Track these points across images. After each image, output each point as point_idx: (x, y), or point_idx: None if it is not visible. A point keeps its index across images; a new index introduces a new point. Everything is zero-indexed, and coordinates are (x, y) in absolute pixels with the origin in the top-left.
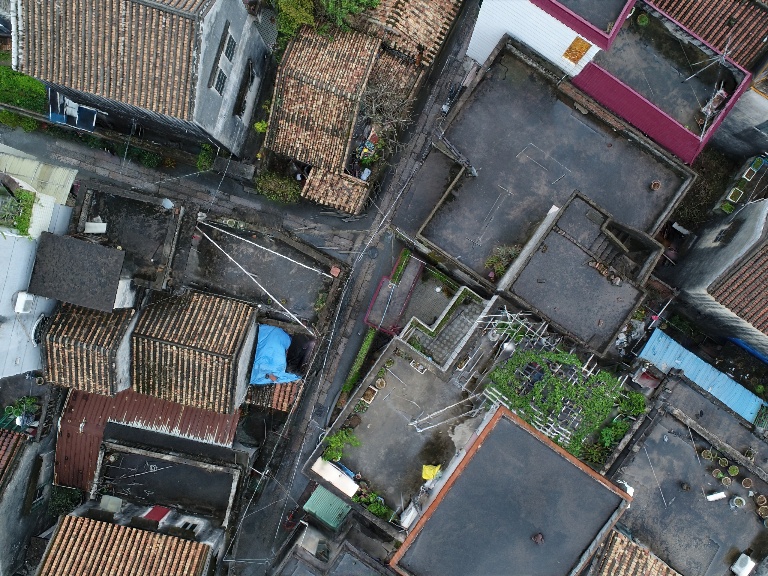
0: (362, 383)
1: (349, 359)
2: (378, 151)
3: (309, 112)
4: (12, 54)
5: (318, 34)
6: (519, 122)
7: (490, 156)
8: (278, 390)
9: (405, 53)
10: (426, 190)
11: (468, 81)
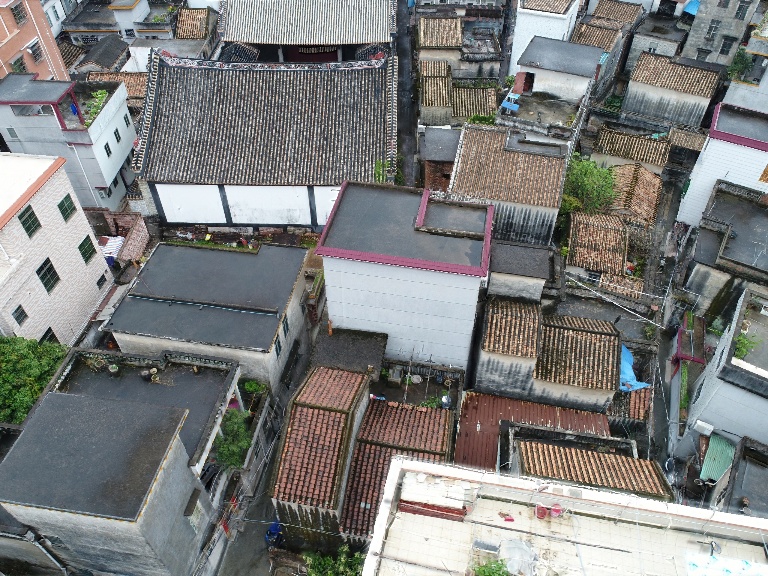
0: (739, 312)
1: (661, 411)
2: None
3: (596, 240)
4: (450, 183)
5: None
6: (745, 216)
7: (738, 230)
8: (633, 398)
9: (637, 223)
10: (708, 245)
11: (668, 254)
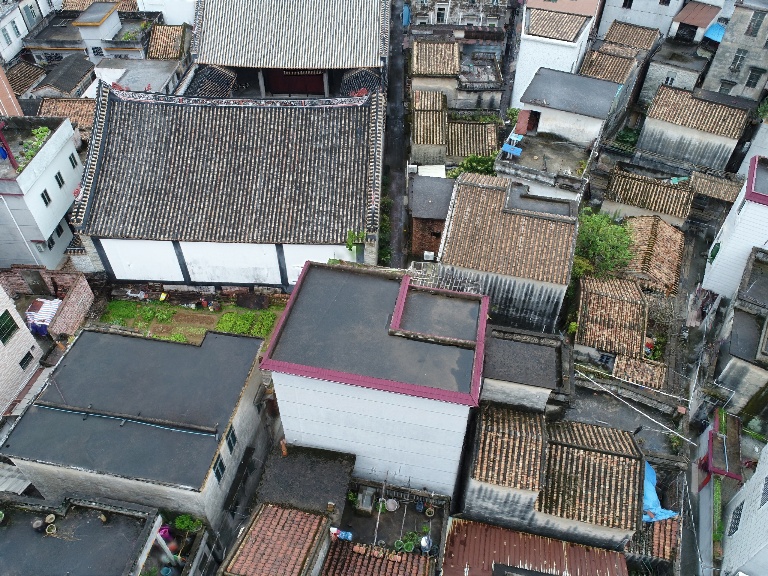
0: None
1: (688, 533)
2: (657, 350)
3: (609, 315)
4: (439, 251)
5: (596, 277)
6: None
7: None
8: (657, 531)
9: (656, 290)
10: (745, 333)
11: (691, 323)
